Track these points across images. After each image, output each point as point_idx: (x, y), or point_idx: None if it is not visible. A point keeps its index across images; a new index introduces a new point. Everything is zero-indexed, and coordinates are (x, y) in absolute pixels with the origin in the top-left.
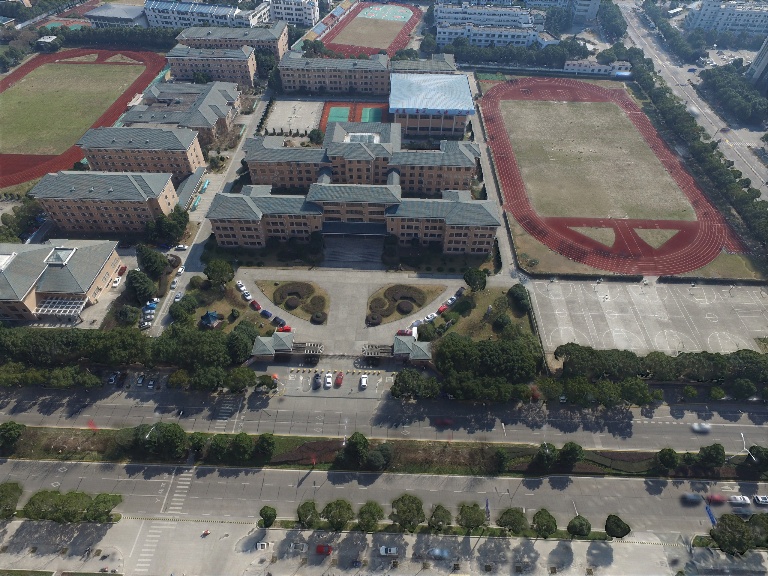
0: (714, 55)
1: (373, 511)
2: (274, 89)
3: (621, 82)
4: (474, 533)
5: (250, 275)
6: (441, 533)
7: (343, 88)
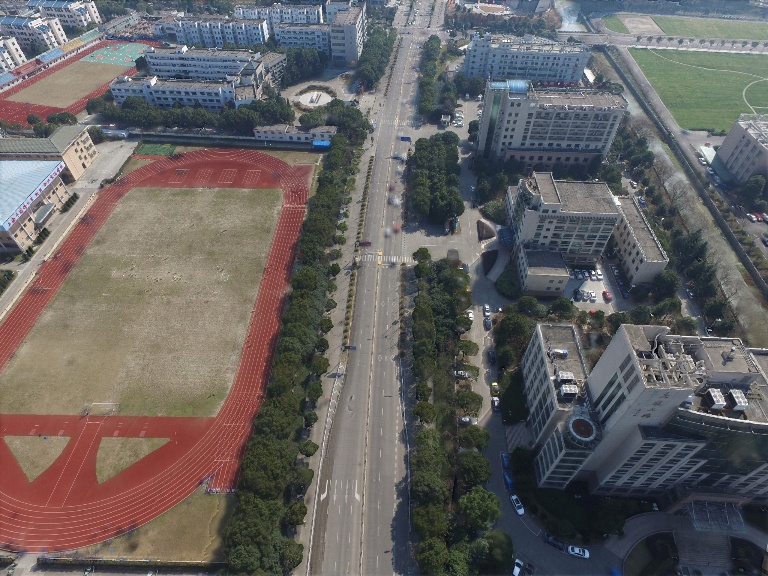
0: (472, 109)
1: None
2: None
3: (319, 155)
4: None
5: None
6: None
7: None
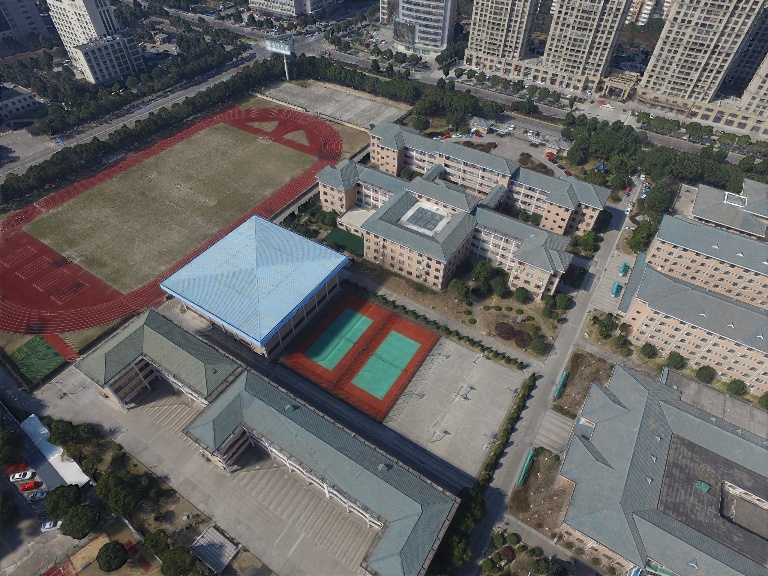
0: None
1: None
2: None
3: None
4: (492, 90)
5: None
6: (504, 93)
7: None
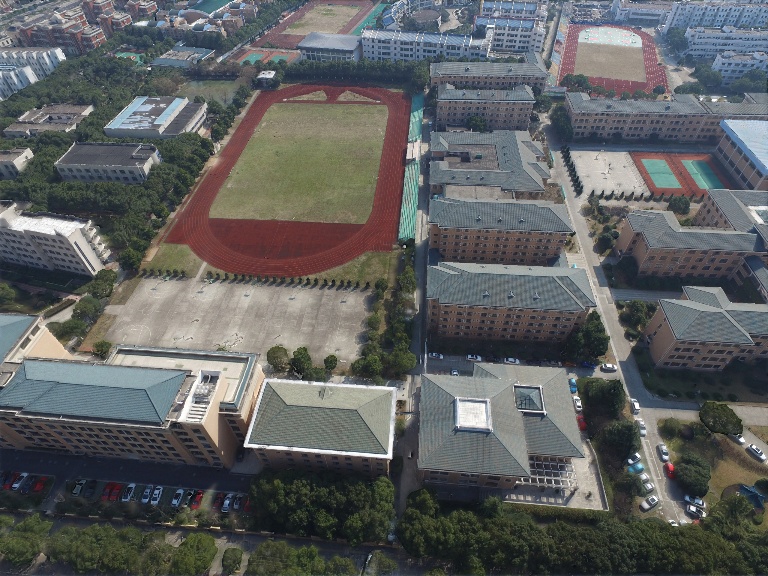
0: None
1: None
2: (565, 137)
3: None
4: None
5: None
6: None
7: (642, 134)
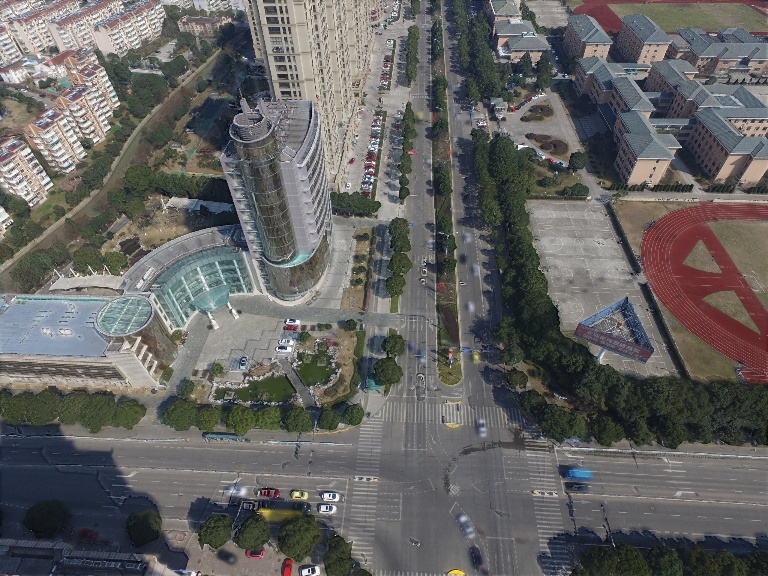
0: None
1: (409, 121)
2: None
3: None
4: None
5: (552, 97)
6: None
7: None
